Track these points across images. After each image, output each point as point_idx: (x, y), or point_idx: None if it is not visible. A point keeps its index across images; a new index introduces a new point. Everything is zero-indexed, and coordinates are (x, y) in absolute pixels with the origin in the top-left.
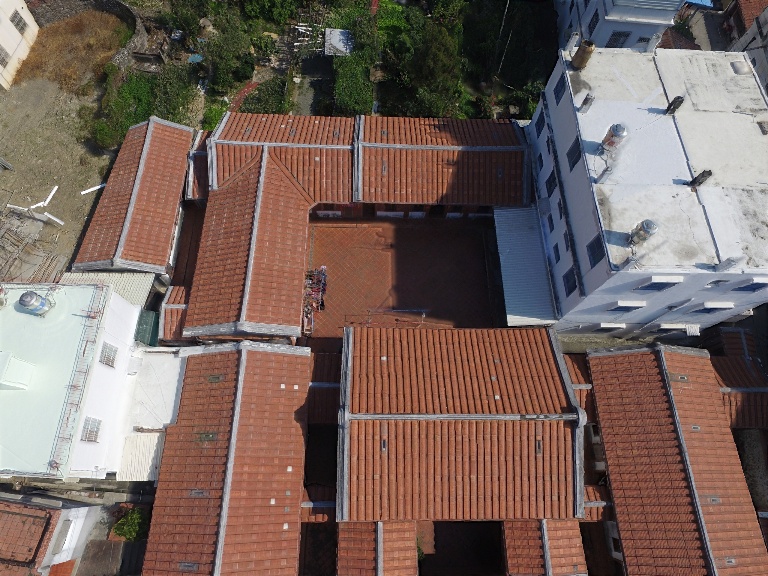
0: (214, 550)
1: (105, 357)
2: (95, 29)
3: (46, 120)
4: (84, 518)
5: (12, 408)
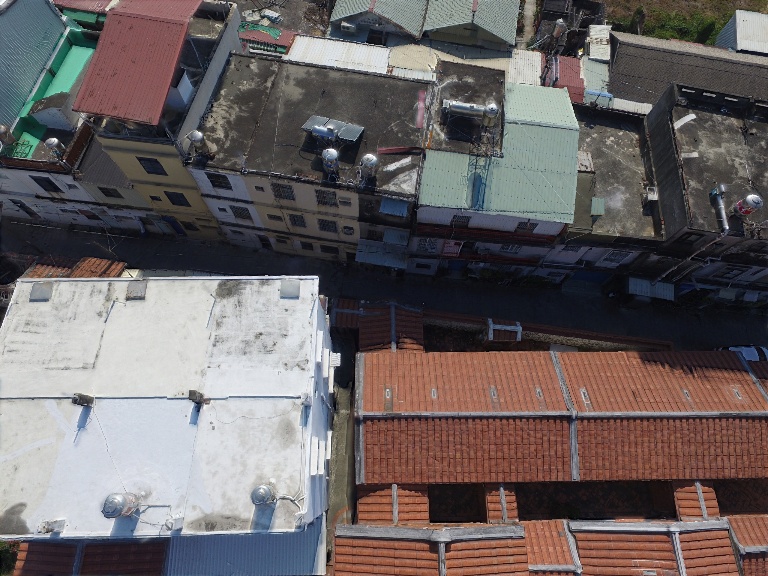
0: None
1: None
2: None
3: None
4: None
5: None
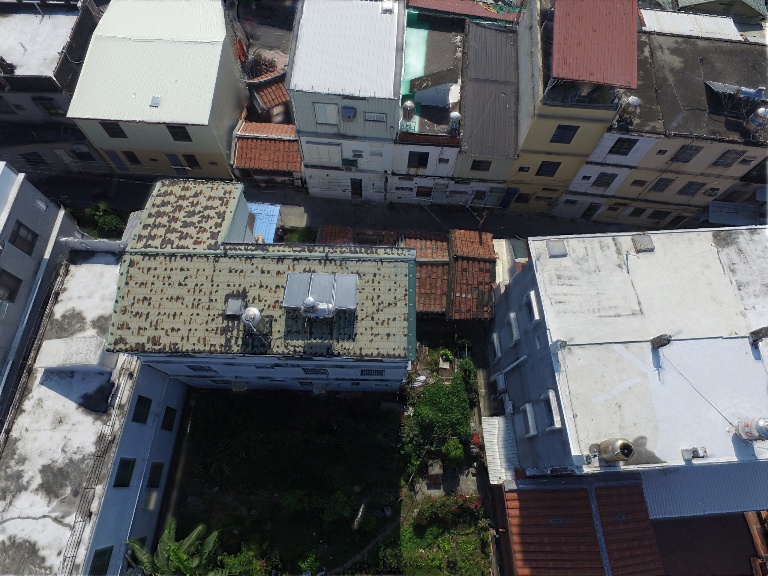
0: None
1: None
2: None
3: None
4: None
5: None
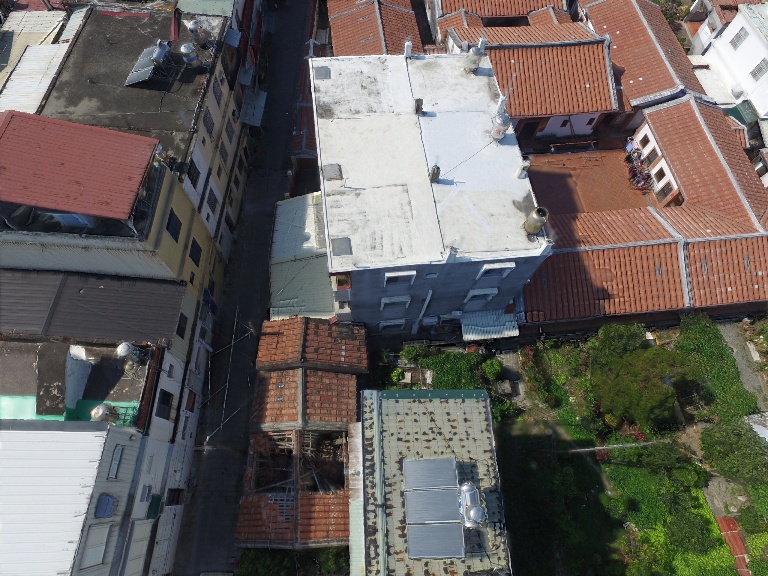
0: None
1: (762, 66)
2: None
3: None
4: None
5: None
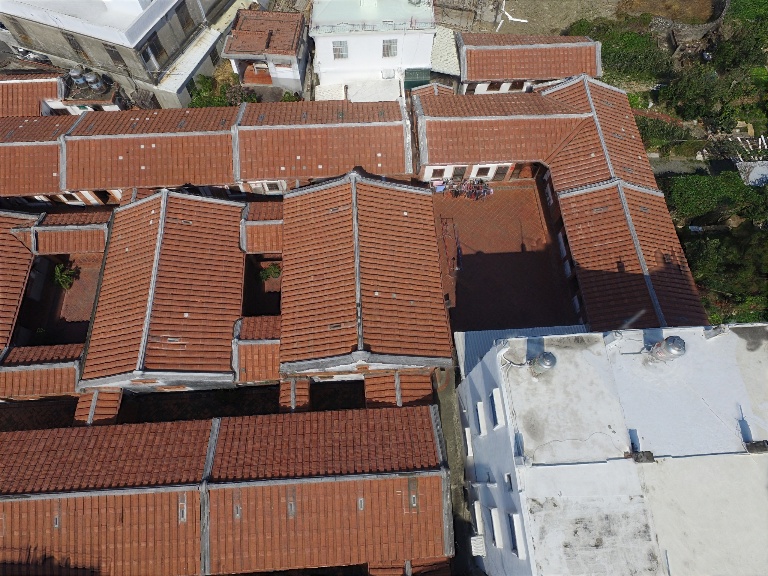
0: None
1: (388, 45)
2: (691, 7)
3: (585, 2)
4: (294, 78)
5: (349, 4)
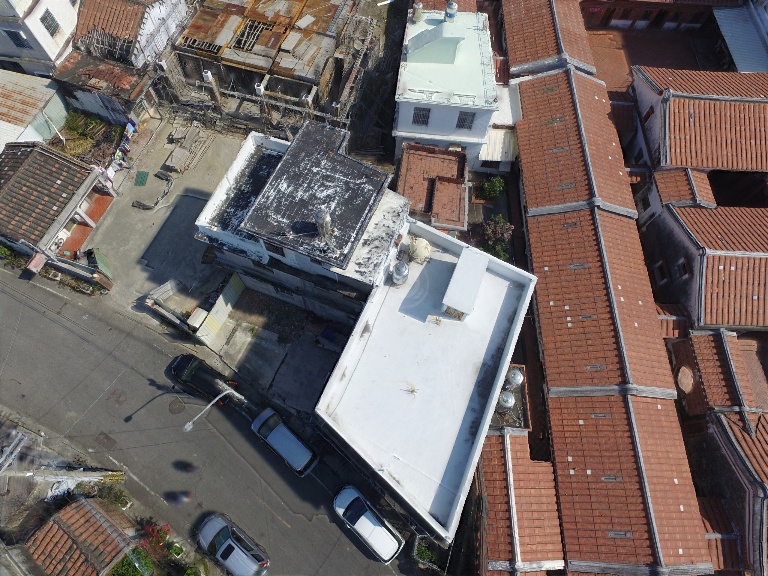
0: (586, 173)
1: None
2: None
3: None
4: None
5: (449, 73)
